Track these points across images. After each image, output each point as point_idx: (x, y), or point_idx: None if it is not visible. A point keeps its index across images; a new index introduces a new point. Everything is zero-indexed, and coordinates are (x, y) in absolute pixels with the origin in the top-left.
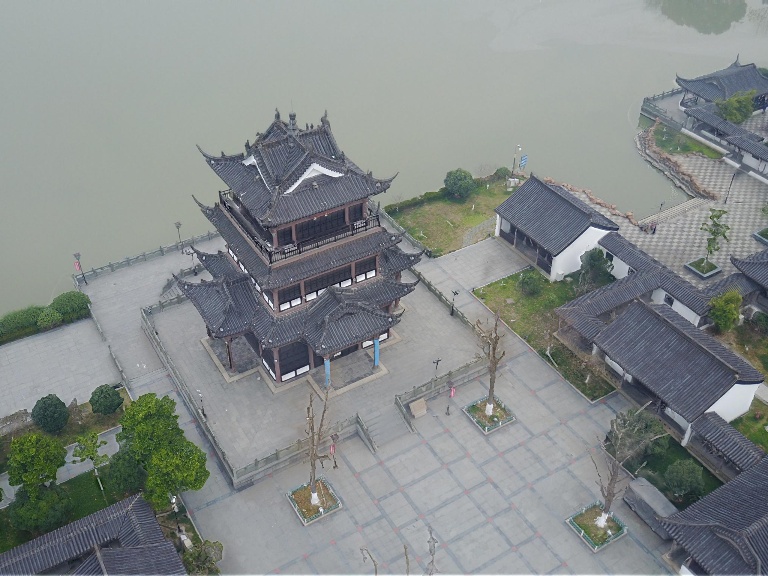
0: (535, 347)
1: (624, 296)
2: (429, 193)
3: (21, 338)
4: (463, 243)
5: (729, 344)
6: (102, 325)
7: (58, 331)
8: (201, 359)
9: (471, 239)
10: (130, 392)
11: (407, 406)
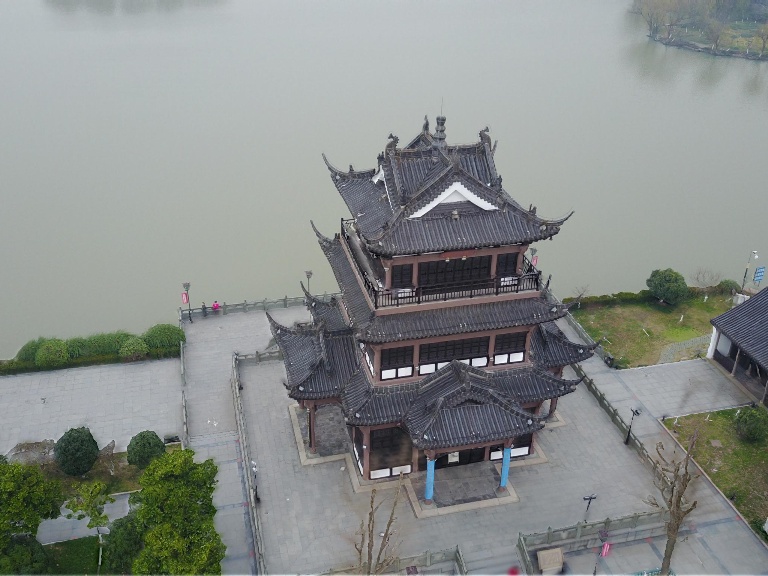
0: (746, 515)
1: None
2: (625, 293)
3: (98, 364)
4: (660, 358)
5: None
6: (188, 368)
7: (139, 365)
8: (281, 429)
9: (672, 356)
10: None
11: (533, 554)
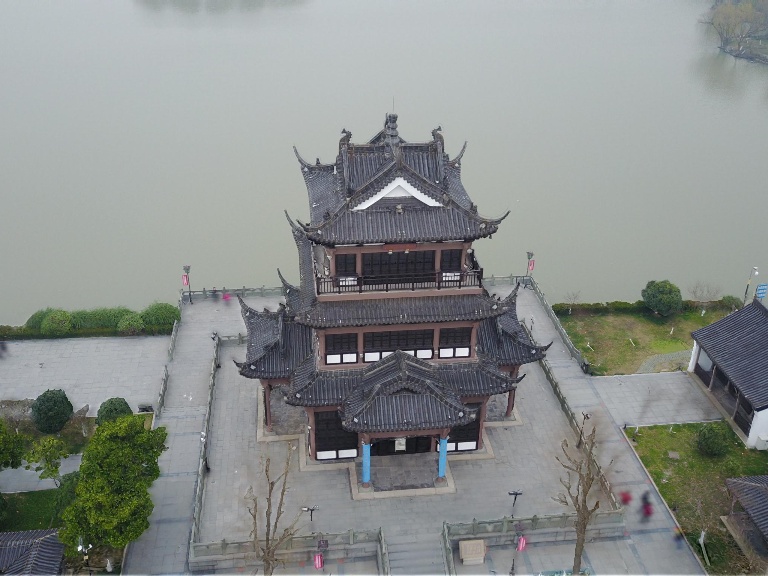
0: (685, 526)
1: None
2: (619, 302)
3: (97, 336)
4: (639, 368)
5: None
6: (178, 345)
7: (134, 339)
8: (246, 407)
9: (652, 366)
10: (156, 420)
11: (456, 543)
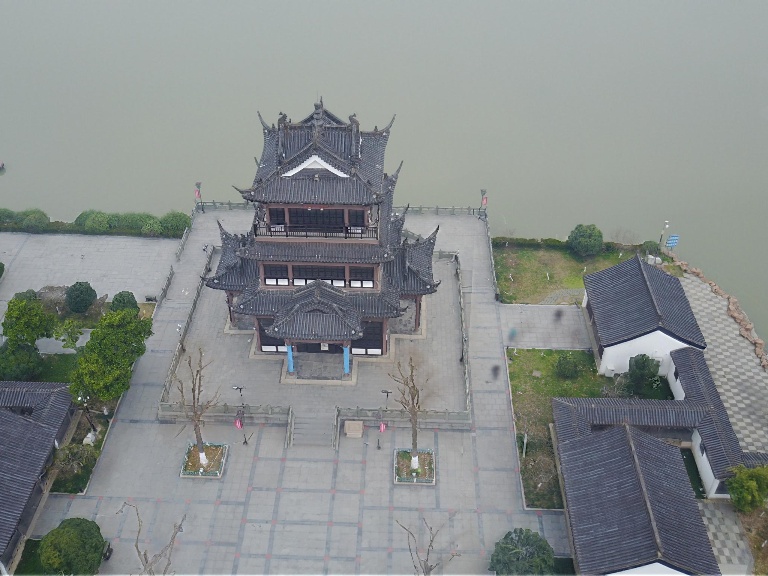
0: None
1: (641, 418)
2: (551, 240)
3: (127, 235)
4: (543, 300)
5: (747, 529)
6: (186, 248)
7: (154, 240)
8: (223, 305)
9: (555, 299)
10: (157, 308)
11: (343, 421)
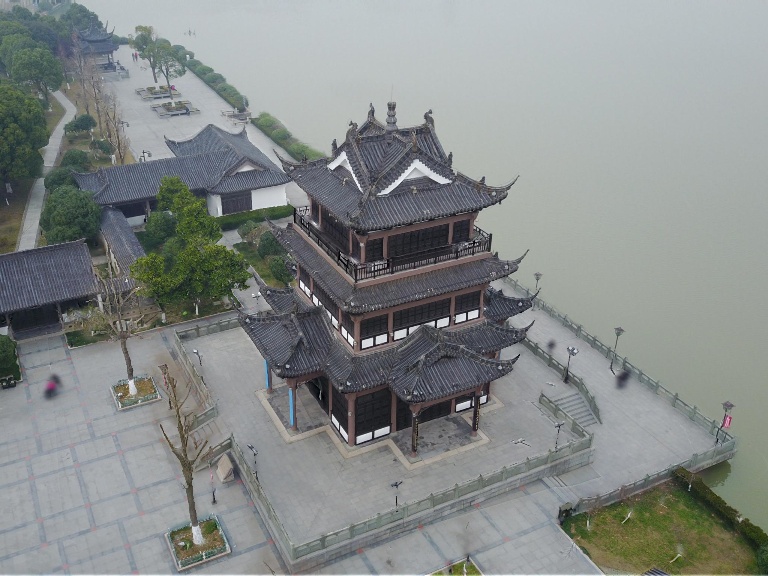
0: None
1: None
2: (757, 529)
3: None
4: (614, 568)
5: None
6: None
7: None
8: None
9: None
10: None
11: None
